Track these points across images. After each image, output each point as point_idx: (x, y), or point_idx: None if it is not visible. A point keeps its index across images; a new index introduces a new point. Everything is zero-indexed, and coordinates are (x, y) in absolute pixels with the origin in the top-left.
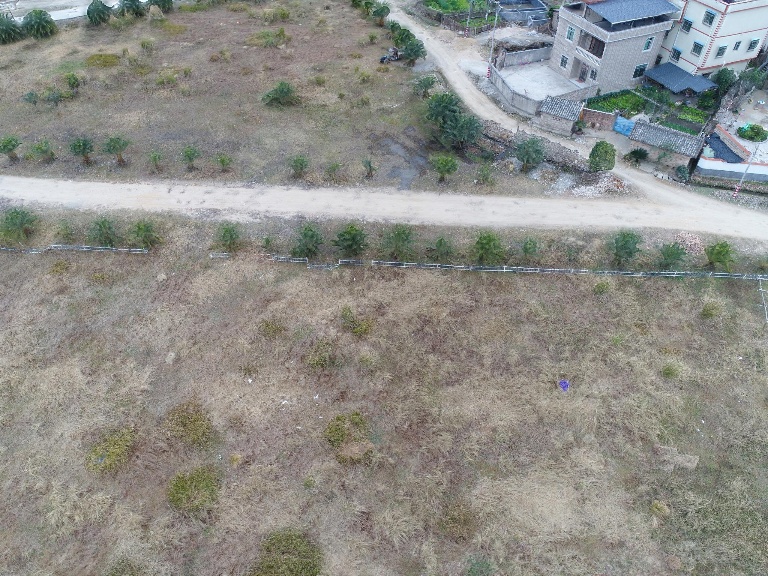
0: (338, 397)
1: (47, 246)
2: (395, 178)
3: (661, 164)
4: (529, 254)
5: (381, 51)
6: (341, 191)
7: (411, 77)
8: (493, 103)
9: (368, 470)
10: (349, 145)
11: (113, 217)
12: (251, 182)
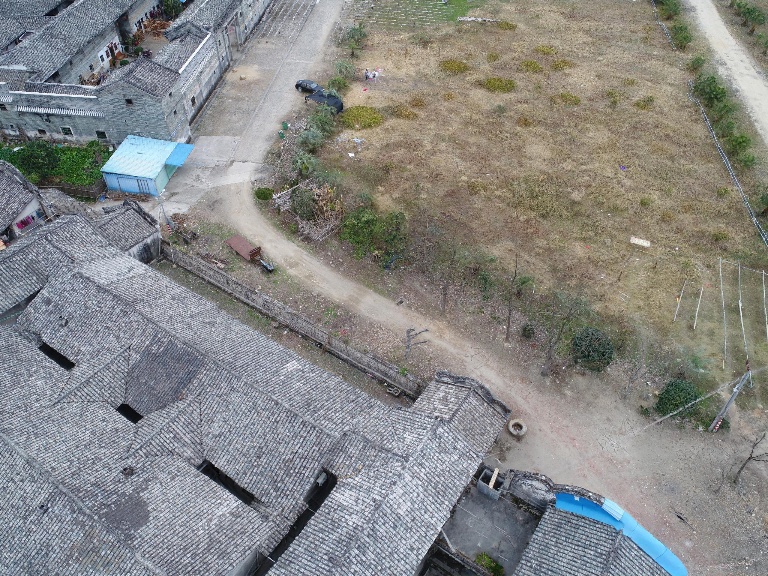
0: (590, 98)
1: None
2: None
3: None
4: None
5: None
6: None
7: None
8: None
9: None
10: None
11: (698, 37)
12: (765, 74)
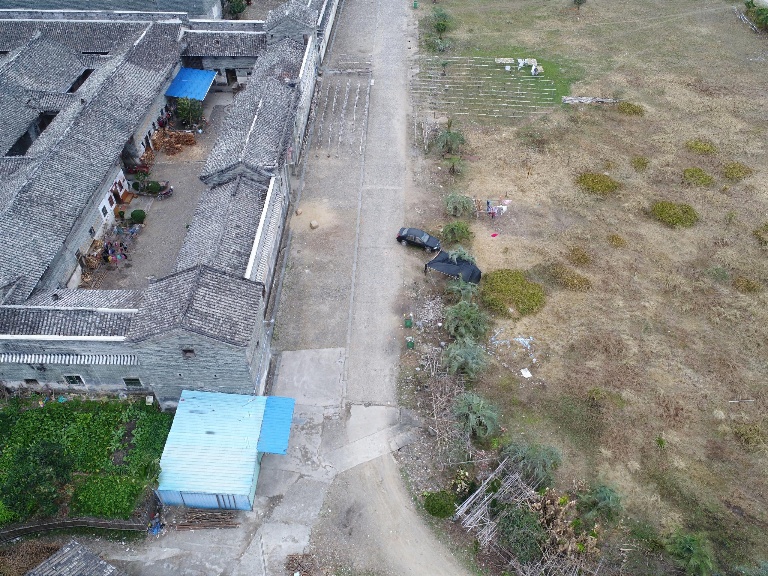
0: None
1: None
2: None
3: None
4: None
5: None
6: None
7: None
8: None
9: (757, 246)
10: None
11: None
12: None
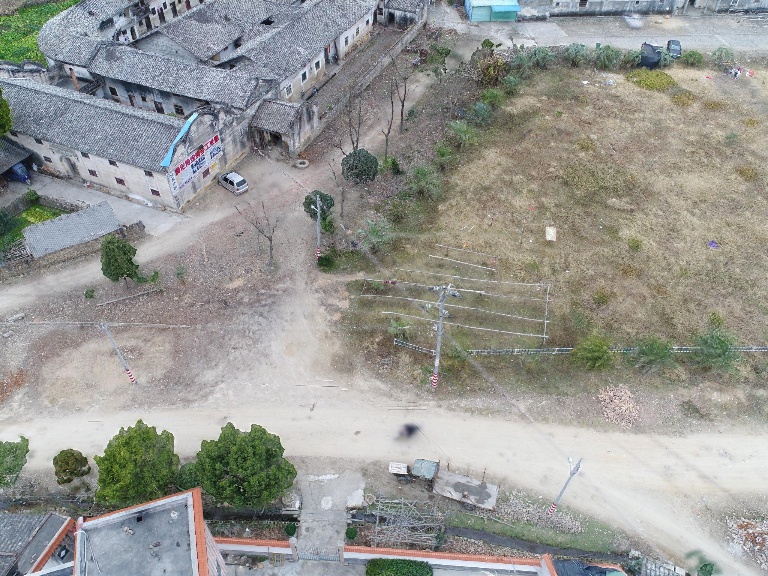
0: None
1: None
2: None
3: None
4: None
5: None
6: None
7: None
8: None
9: None
10: None
11: None
12: None
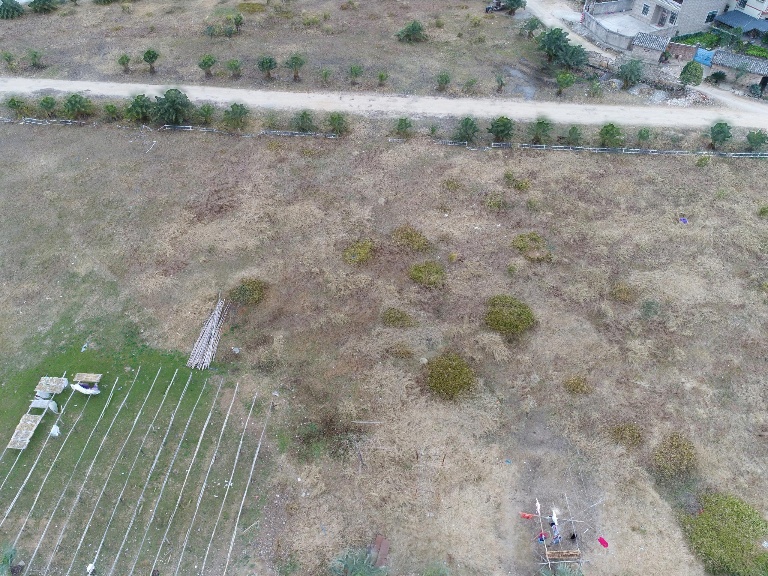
0: (516, 225)
1: (258, 133)
2: (520, 92)
3: (737, 84)
4: (643, 140)
5: (483, 4)
6: (479, 100)
7: (514, 23)
8: (588, 42)
9: (550, 266)
10: (476, 70)
11: None
12: (404, 93)
